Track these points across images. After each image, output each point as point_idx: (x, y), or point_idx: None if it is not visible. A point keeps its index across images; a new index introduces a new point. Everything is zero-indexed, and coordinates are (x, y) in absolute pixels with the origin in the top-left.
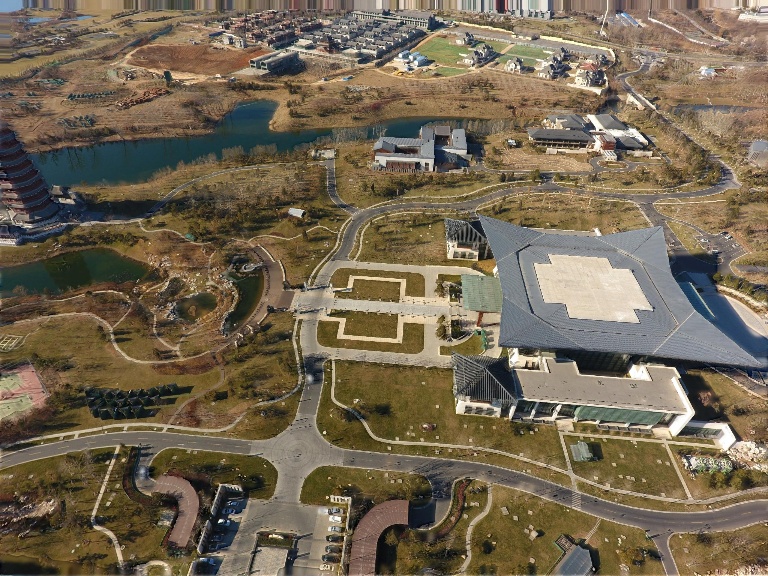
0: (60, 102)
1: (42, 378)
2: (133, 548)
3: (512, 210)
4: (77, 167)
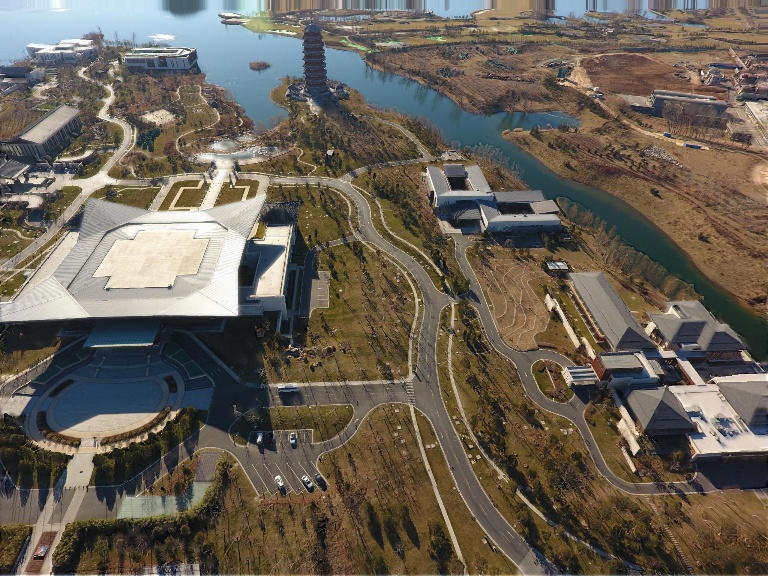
0: (478, 61)
1: (169, 120)
2: (67, 155)
3: None
4: (418, 98)
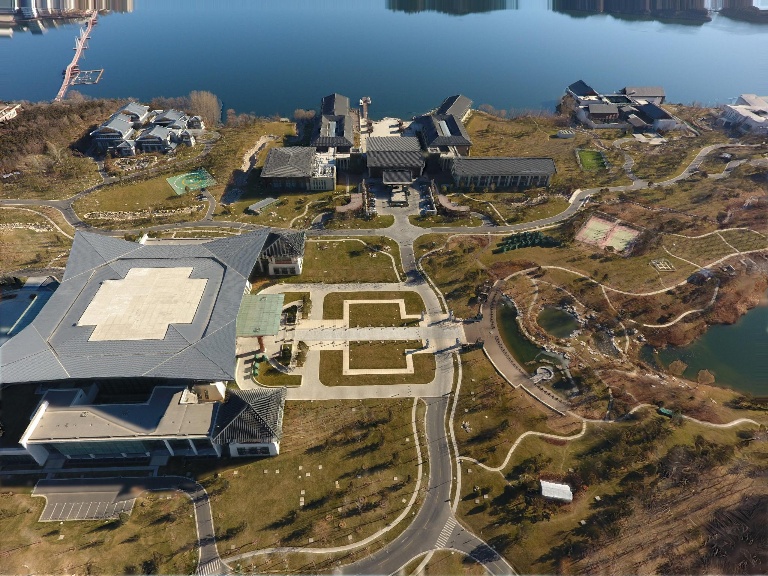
0: None
1: None
2: (462, 198)
3: (114, 572)
4: None
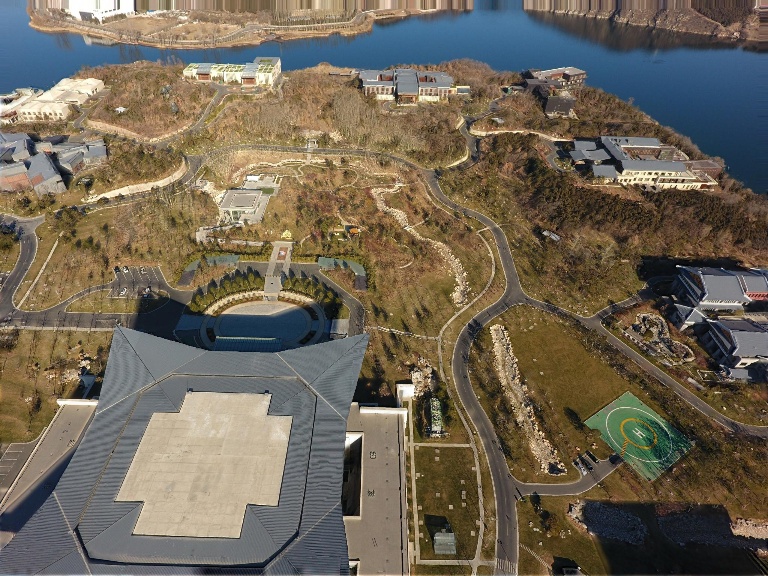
0: None
1: None
2: None
3: None
4: None
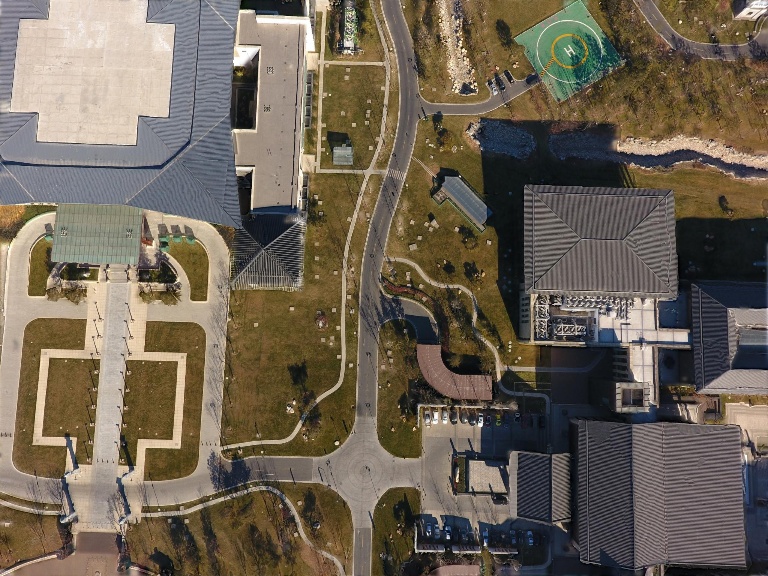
0: None
1: None
2: None
3: None
4: None
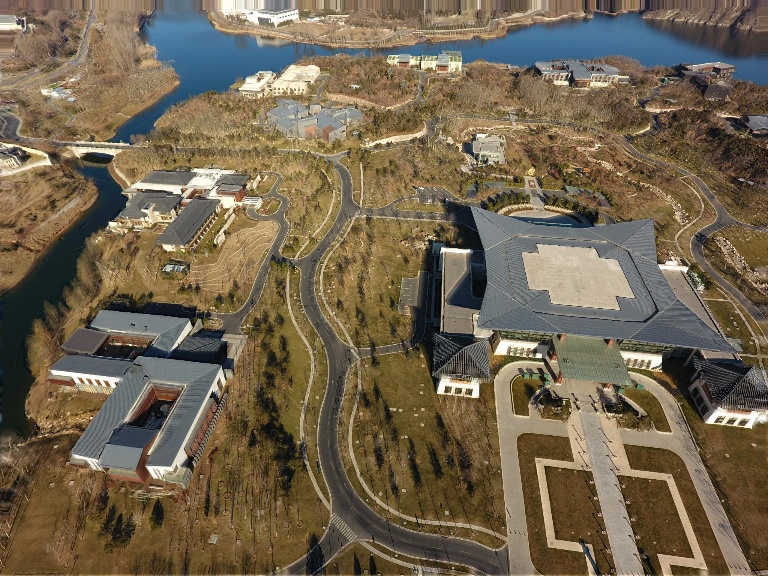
0: None
1: None
2: None
3: (363, 309)
4: None
